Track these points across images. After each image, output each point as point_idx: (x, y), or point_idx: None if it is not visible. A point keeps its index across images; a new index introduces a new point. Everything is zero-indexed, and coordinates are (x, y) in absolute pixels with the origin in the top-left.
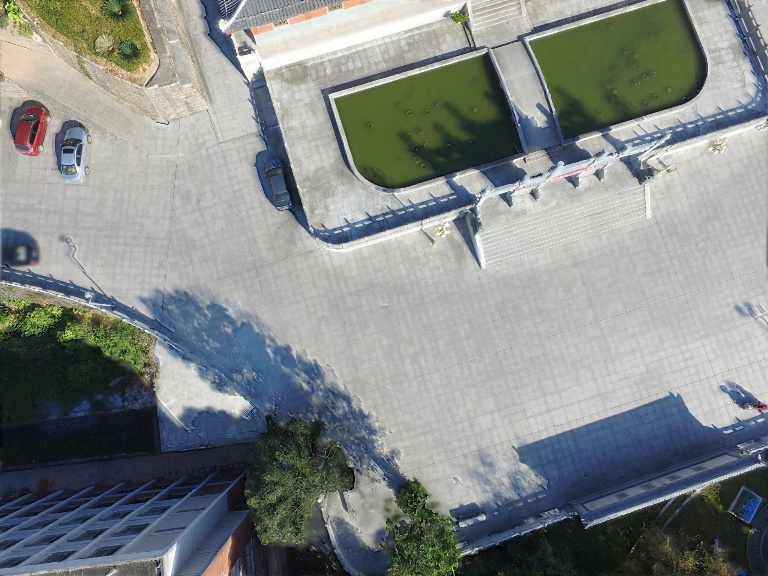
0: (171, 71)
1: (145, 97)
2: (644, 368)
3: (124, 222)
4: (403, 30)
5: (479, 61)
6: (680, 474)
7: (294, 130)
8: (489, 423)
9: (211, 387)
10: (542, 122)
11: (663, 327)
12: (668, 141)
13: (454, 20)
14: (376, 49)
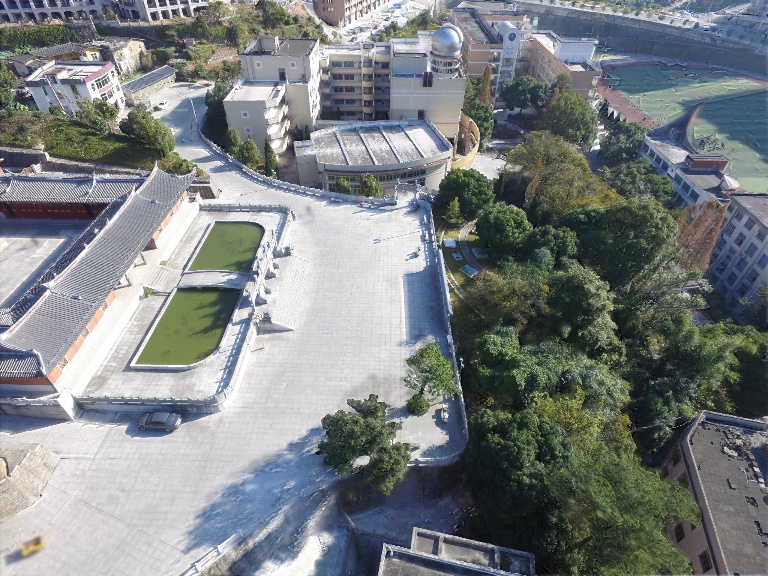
0: (17, 452)
1: (10, 489)
2: (385, 282)
3: (86, 568)
4: (128, 321)
5: (178, 294)
6: (440, 280)
7: (133, 395)
8: (386, 352)
9: (282, 573)
10: (233, 277)
11: (367, 271)
12: None
13: (146, 298)
14: (126, 337)
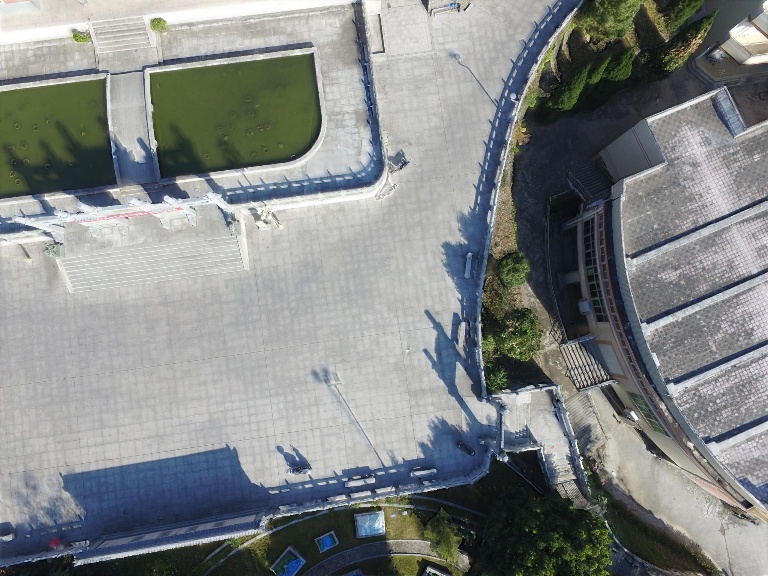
0: None
1: None
2: (207, 417)
3: None
4: (33, 40)
5: (100, 85)
6: (200, 527)
7: None
8: (42, 446)
9: None
10: (140, 157)
11: (236, 379)
12: (270, 196)
13: None
14: (2, 55)
